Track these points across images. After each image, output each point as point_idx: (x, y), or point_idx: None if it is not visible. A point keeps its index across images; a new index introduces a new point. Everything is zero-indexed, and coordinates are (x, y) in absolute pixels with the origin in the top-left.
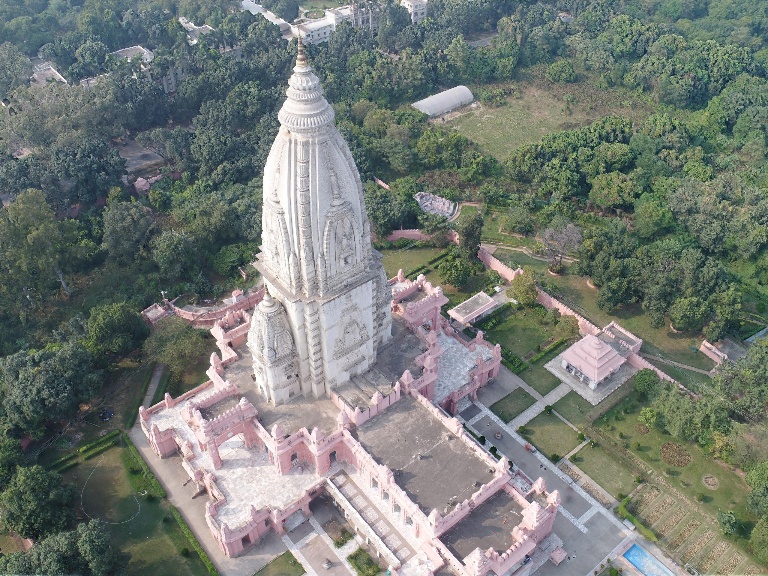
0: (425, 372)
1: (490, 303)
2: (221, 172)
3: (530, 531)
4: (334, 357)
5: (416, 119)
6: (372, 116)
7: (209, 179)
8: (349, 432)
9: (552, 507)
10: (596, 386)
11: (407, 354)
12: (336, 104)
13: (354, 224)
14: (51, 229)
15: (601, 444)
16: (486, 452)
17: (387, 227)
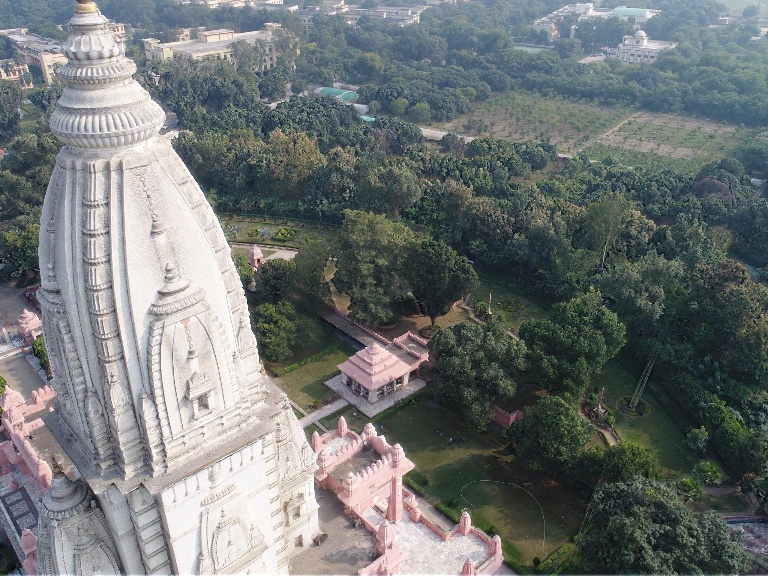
0: None
1: None
2: None
3: None
4: None
5: None
6: None
7: None
8: None
9: None
10: None
11: None
12: None
13: None
14: None
15: None
16: None
17: None
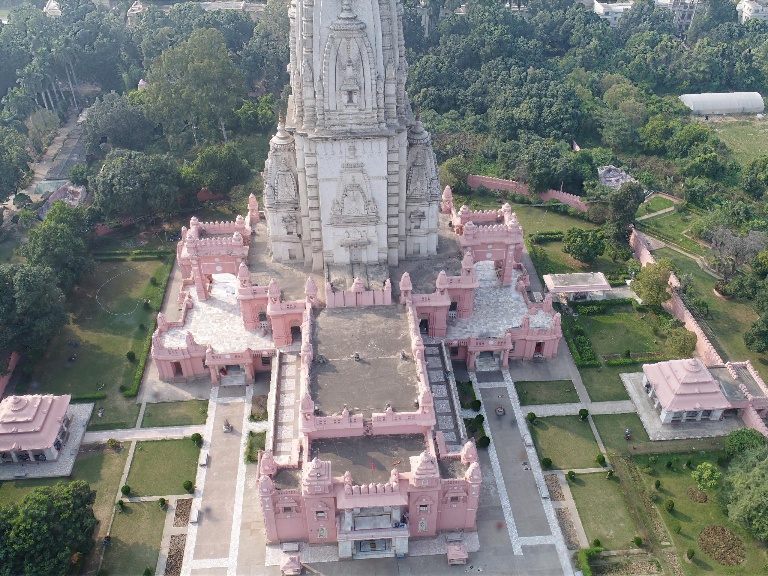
0: (436, 291)
1: (600, 285)
2: (422, 95)
3: (411, 486)
4: (329, 221)
5: (671, 108)
6: (615, 89)
7: (411, 100)
8: (311, 306)
9: (466, 483)
10: (669, 420)
11: (436, 272)
12: (581, 68)
13: (364, 53)
14: (213, 67)
15: (623, 481)
16: (454, 405)
17: (544, 182)
